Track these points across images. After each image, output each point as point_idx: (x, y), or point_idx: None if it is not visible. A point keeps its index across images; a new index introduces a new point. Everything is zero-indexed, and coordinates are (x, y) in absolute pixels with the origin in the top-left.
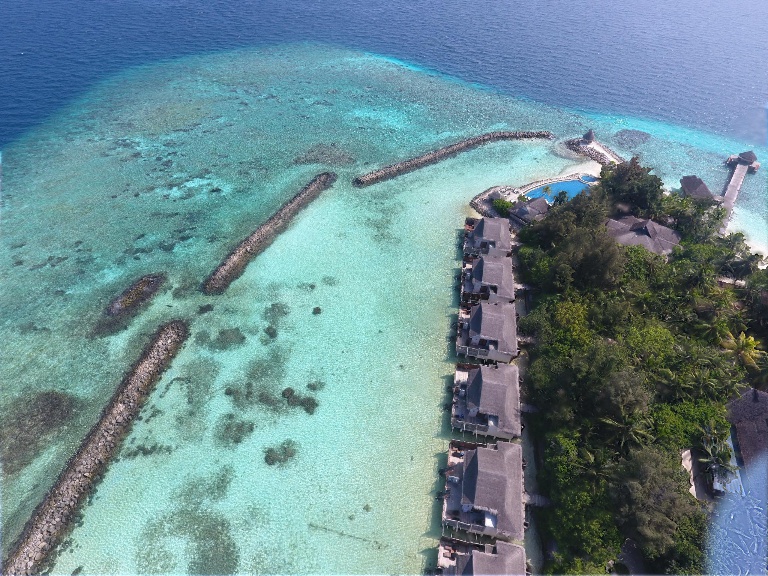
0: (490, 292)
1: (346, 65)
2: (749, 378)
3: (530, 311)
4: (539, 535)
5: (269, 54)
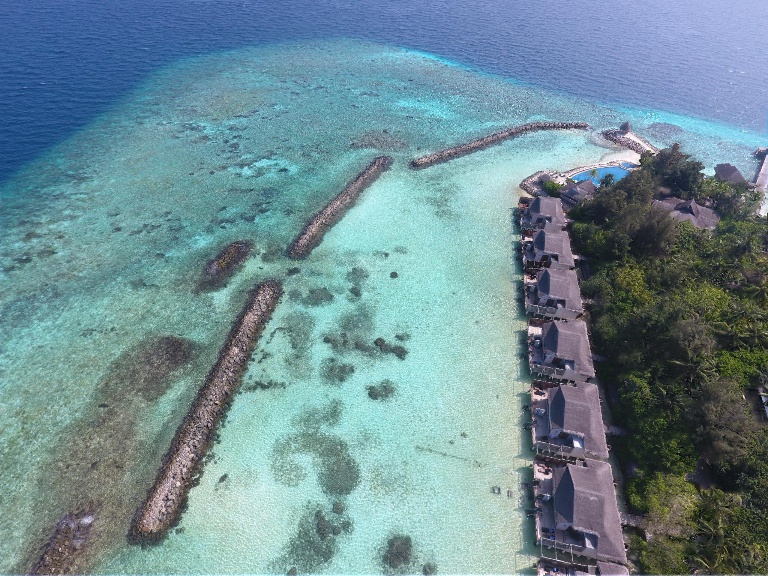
0: (552, 260)
1: (385, 59)
2: None
3: (590, 277)
4: (617, 459)
5: (311, 48)
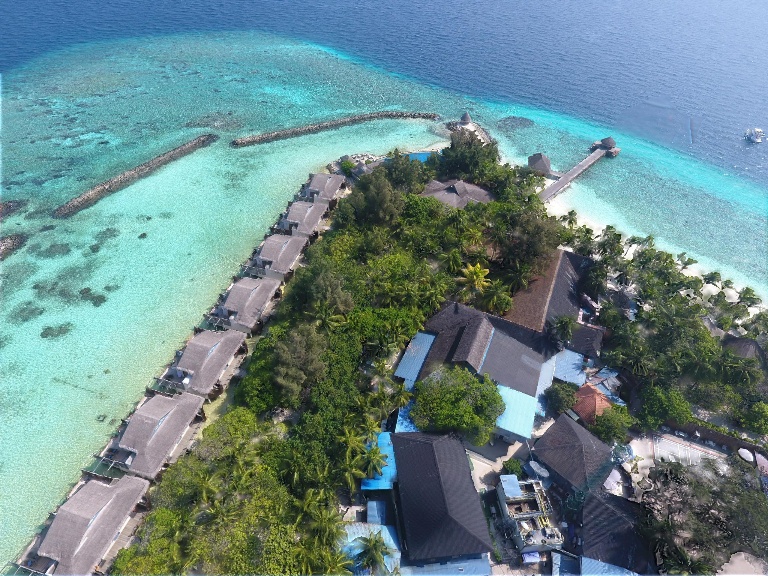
0: (292, 228)
1: (279, 51)
2: (477, 302)
3: None
4: None
5: (212, 38)
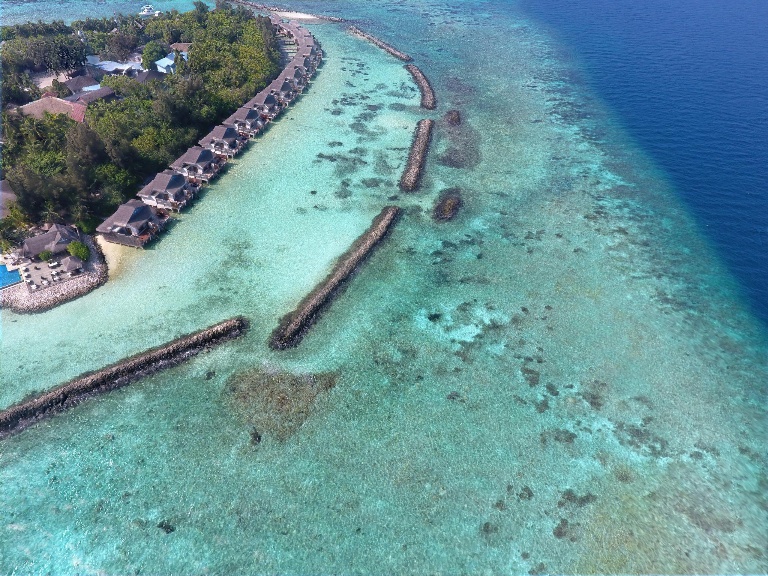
0: None
1: None
2: None
3: None
4: None
5: None
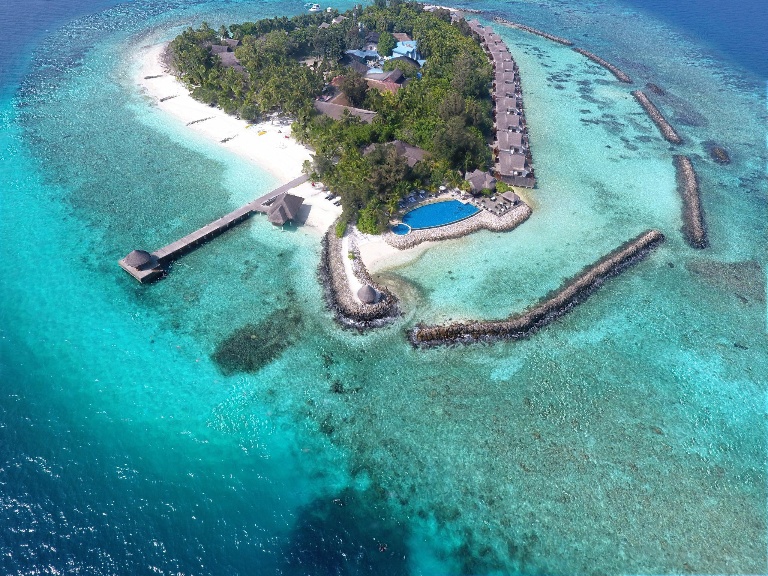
0: None
1: None
2: None
3: None
4: None
5: None
